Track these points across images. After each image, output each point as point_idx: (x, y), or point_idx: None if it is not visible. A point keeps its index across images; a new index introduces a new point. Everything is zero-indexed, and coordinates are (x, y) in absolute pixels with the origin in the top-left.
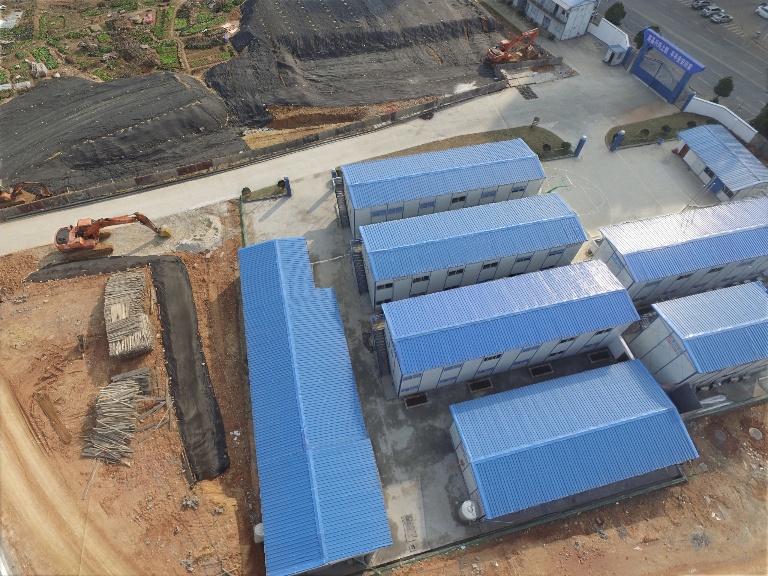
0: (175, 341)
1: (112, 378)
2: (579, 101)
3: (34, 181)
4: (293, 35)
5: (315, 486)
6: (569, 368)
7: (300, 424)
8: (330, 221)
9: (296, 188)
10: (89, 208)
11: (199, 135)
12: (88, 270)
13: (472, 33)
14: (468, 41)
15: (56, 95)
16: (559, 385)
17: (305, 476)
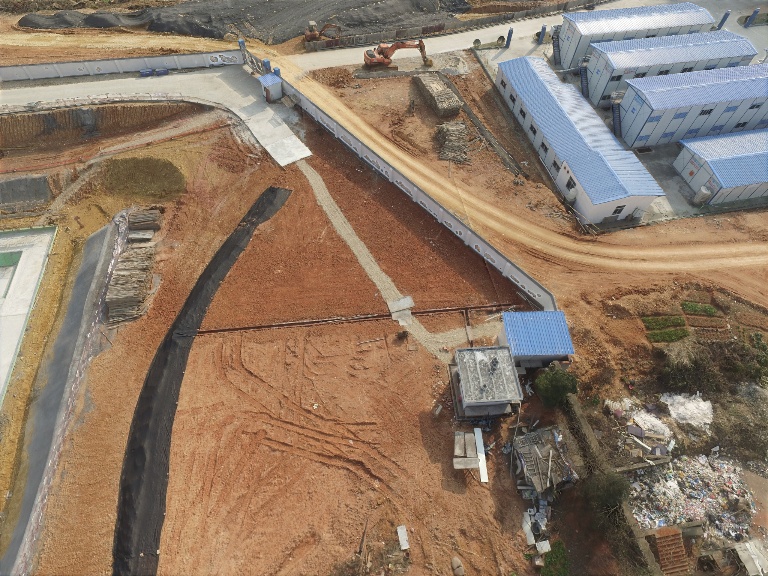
0: None
1: None
2: (709, 1)
3: None
4: None
5: (609, 165)
6: None
7: (584, 142)
8: None
9: (510, 44)
10: (368, 48)
11: (423, 13)
12: (395, 73)
13: None
14: None
15: None
16: (752, 133)
17: (600, 161)
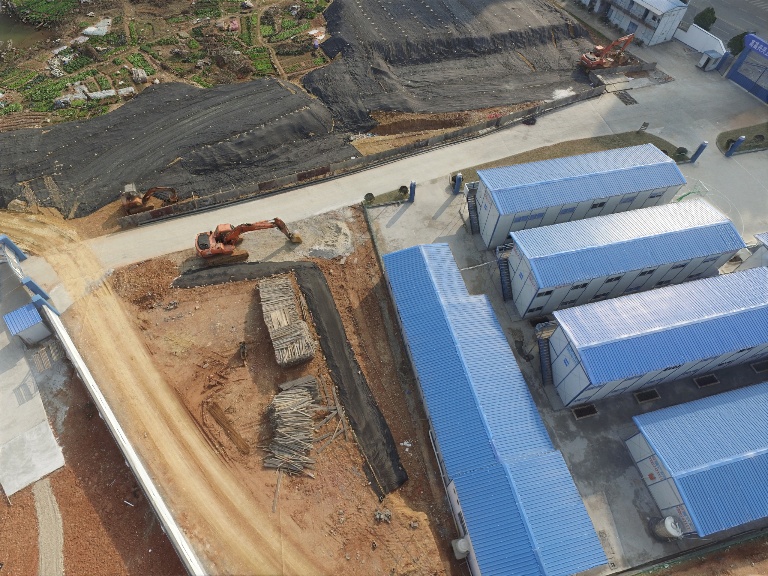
0: (334, 349)
1: (281, 386)
2: (680, 106)
3: (159, 186)
4: (385, 41)
5: (520, 500)
6: (734, 378)
7: (487, 435)
8: (458, 227)
9: (416, 194)
10: (216, 213)
11: (309, 140)
12: None
13: (559, 39)
14: (556, 47)
15: (166, 100)
16: (741, 396)
17: (507, 490)
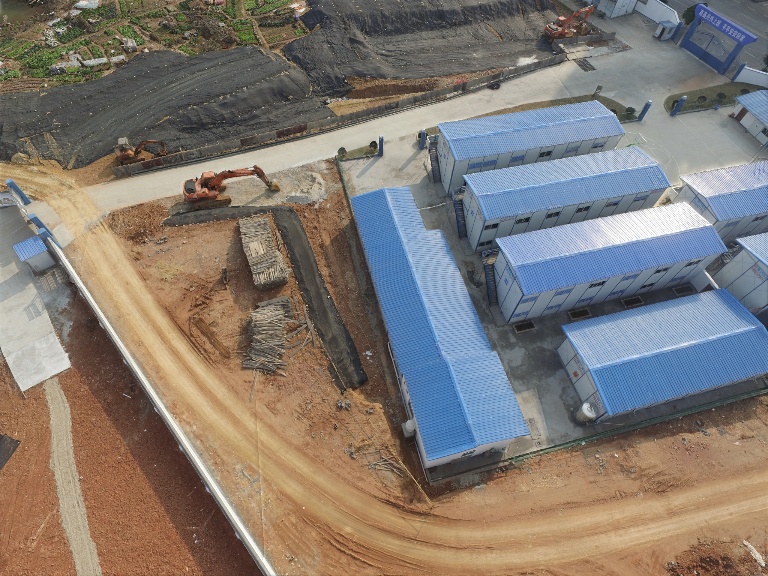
0: (305, 275)
1: (258, 304)
2: (635, 72)
3: None
4: (361, 13)
5: (458, 387)
6: (657, 300)
7: (434, 339)
8: (422, 177)
9: (385, 149)
10: (202, 165)
11: (288, 103)
12: (217, 216)
13: (527, 11)
14: (523, 19)
15: (155, 66)
16: (656, 309)
17: (447, 379)
